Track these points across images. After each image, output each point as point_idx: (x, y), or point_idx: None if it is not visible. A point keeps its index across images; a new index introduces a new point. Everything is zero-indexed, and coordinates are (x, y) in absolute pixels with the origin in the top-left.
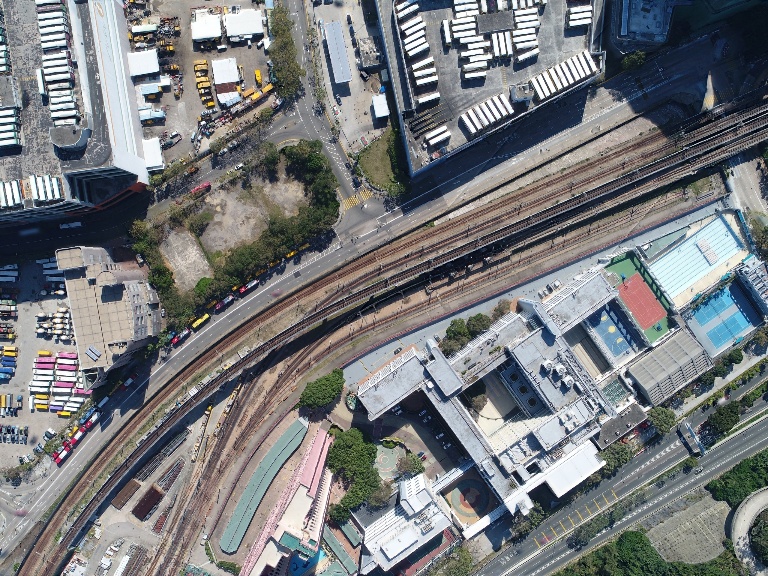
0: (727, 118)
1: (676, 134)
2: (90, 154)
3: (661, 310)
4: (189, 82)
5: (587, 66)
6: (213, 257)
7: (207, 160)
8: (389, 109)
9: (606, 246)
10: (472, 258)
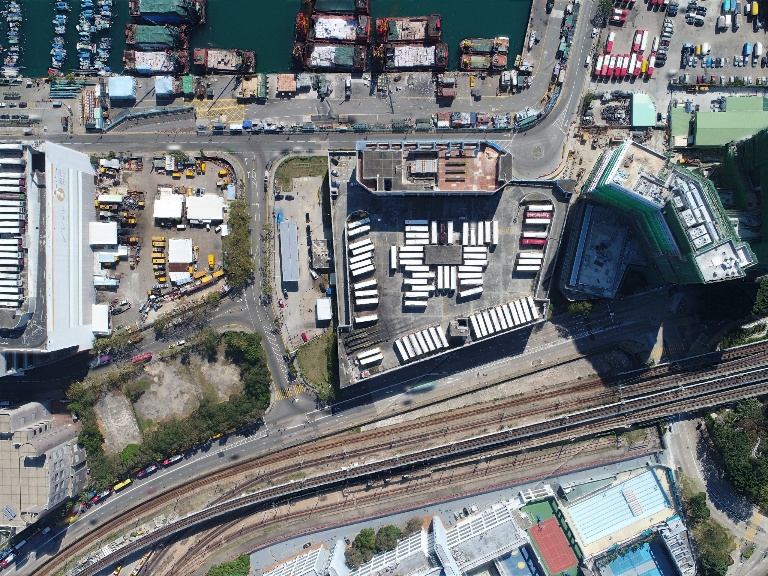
0: (670, 378)
1: (613, 388)
2: (28, 335)
3: (573, 558)
4: (146, 254)
5: (529, 312)
6: (144, 424)
7: (152, 331)
8: (333, 311)
9: (529, 480)
10: (391, 473)
